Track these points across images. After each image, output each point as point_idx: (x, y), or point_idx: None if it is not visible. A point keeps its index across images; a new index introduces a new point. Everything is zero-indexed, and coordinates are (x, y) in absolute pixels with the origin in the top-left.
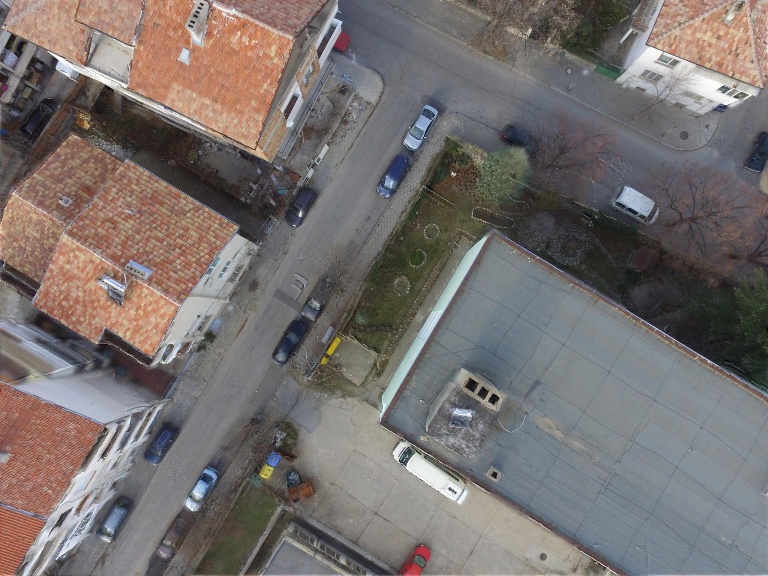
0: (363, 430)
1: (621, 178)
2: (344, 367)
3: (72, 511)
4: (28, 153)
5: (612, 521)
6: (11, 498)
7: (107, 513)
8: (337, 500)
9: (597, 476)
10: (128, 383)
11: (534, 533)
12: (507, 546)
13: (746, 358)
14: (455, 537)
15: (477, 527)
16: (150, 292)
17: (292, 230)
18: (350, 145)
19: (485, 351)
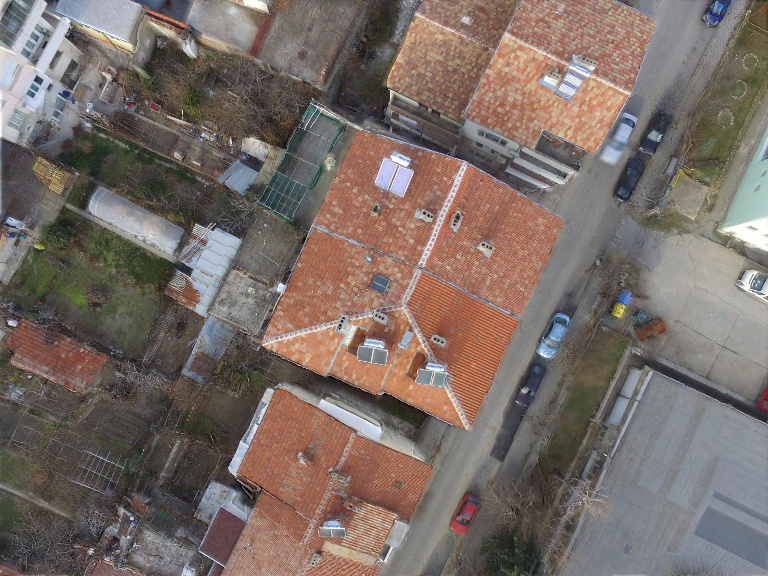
0: (702, 265)
1: None
2: (676, 204)
3: None
4: (366, 7)
5: None
6: (491, 295)
7: None
8: (683, 337)
9: None
10: None
11: None
12: None
13: None
14: None
15: None
16: (597, 84)
17: None
18: None
19: None
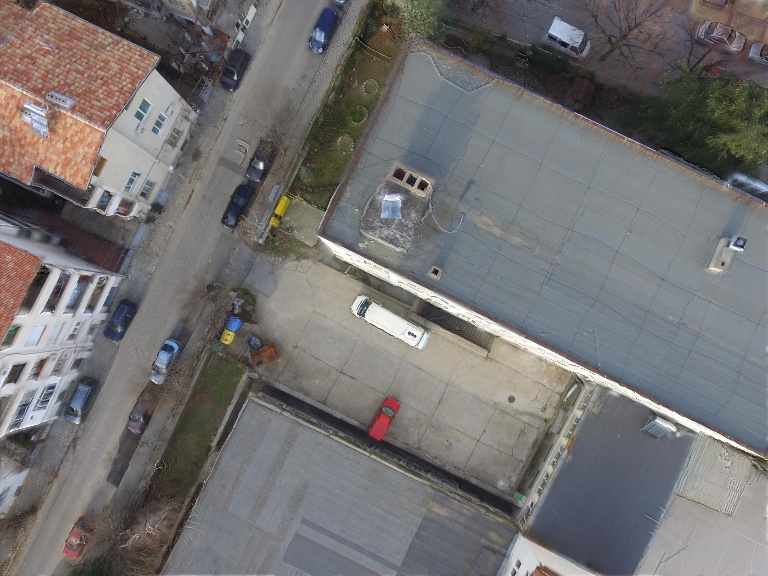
0: (320, 291)
1: (552, 10)
2: (296, 230)
3: (26, 367)
4: None
5: (558, 310)
6: None
7: (72, 394)
8: (301, 363)
9: (539, 268)
10: (75, 248)
11: (500, 377)
12: (474, 392)
13: (680, 146)
14: (422, 388)
15: (443, 376)
16: (74, 121)
17: (230, 95)
18: (279, 3)
19: (416, 156)
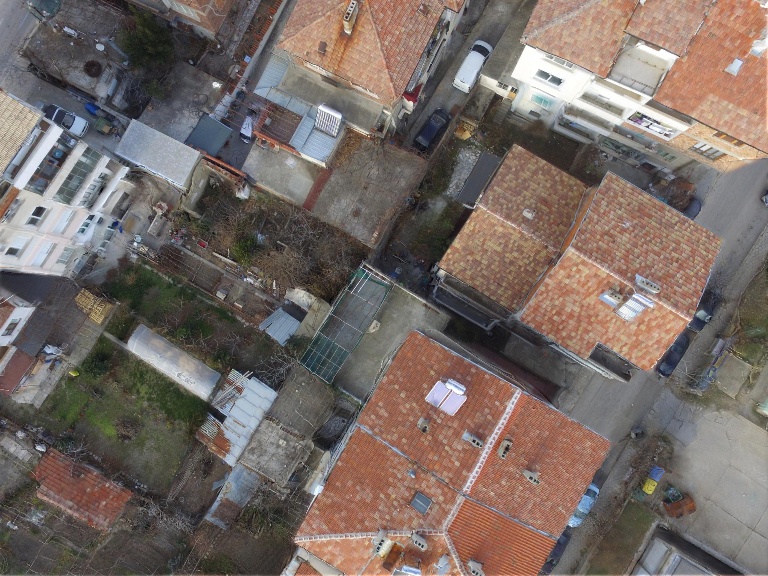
0: (738, 444)
1: None
2: (718, 380)
3: None
4: (423, 164)
5: None
6: (532, 518)
7: None
8: (713, 516)
9: None
10: None
11: None
12: None
13: None
14: None
15: None
16: (658, 307)
17: None
18: None
19: None
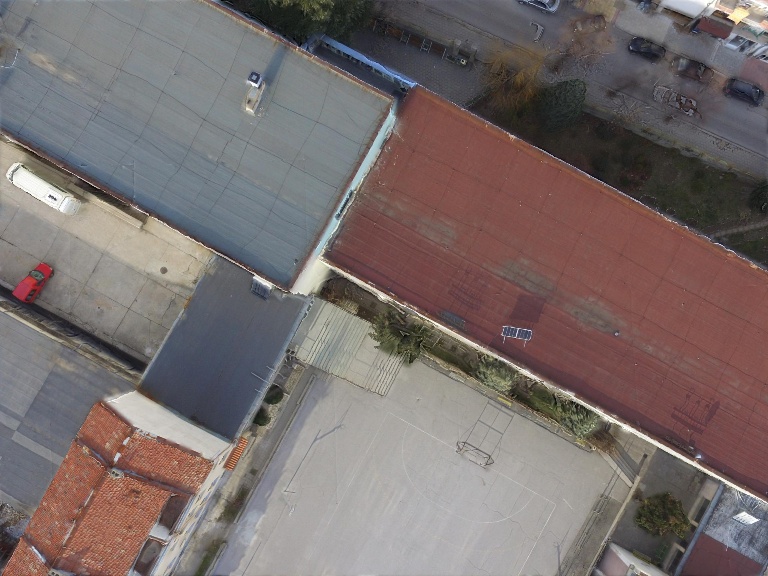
0: None
1: None
2: None
3: None
4: None
5: (100, 144)
6: None
7: None
8: None
9: (86, 104)
10: None
11: (154, 248)
12: (128, 262)
13: (250, 1)
14: (77, 256)
15: (99, 246)
16: None
17: None
18: None
19: None
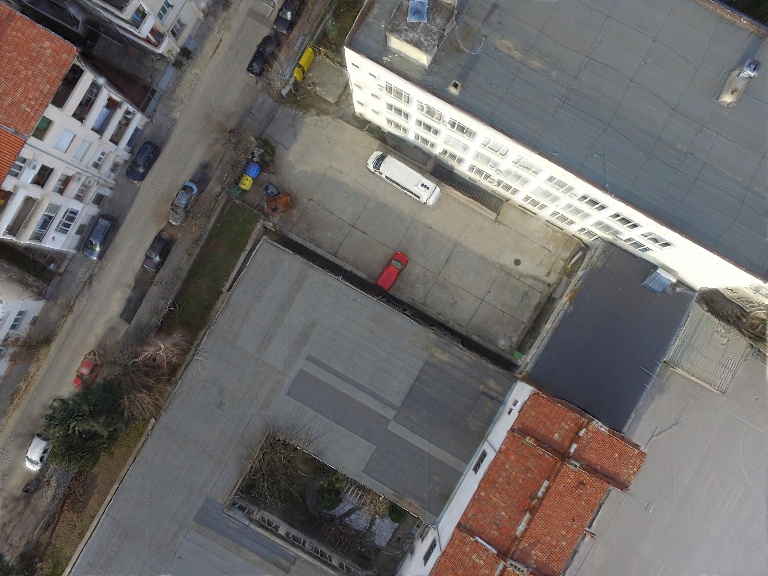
0: (338, 147)
1: None
2: (317, 86)
3: (54, 172)
4: None
5: (570, 132)
6: None
7: (92, 228)
8: (315, 215)
9: (555, 91)
10: (106, 74)
11: (507, 240)
12: (481, 254)
13: None
14: (431, 246)
15: (452, 236)
16: None
17: None
18: None
19: None
